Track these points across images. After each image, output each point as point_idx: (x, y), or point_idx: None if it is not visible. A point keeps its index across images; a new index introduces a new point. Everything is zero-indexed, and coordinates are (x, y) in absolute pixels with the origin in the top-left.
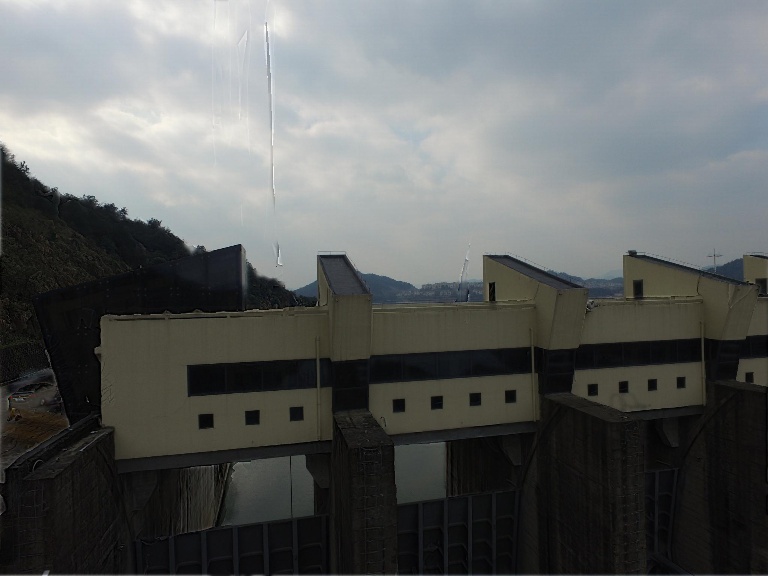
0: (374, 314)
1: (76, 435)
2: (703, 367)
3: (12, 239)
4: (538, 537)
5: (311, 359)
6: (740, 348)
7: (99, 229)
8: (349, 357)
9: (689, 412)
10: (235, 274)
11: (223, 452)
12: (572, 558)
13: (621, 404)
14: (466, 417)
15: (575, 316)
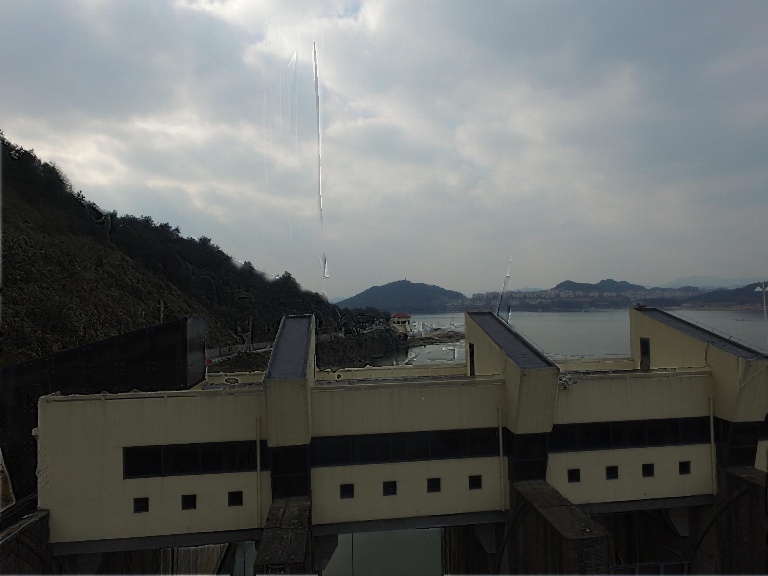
0: (320, 392)
1: (1, 524)
2: (712, 450)
3: (59, 268)
4: None
5: (251, 441)
6: (758, 430)
7: (148, 251)
8: (286, 443)
9: (696, 502)
10: (181, 347)
11: (159, 537)
12: None
13: (609, 492)
14: (423, 504)
15: (545, 398)
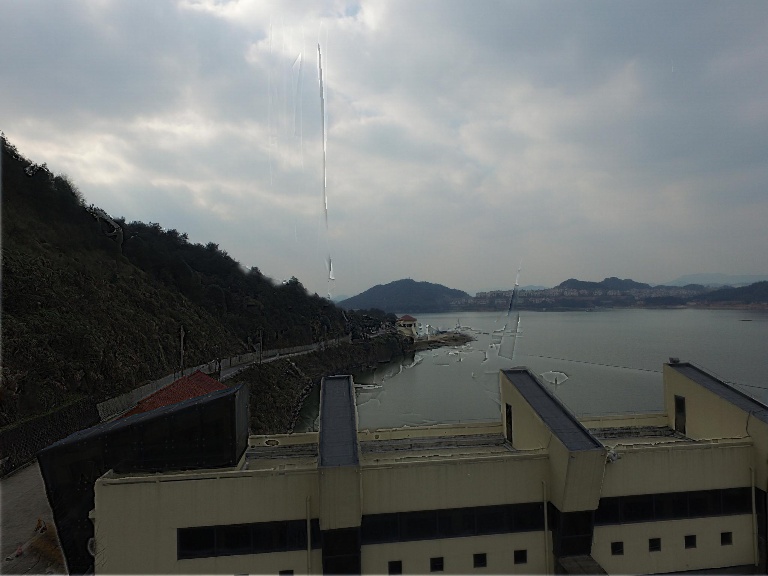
0: (368, 470)
1: None
2: (754, 521)
3: (76, 288)
4: None
5: (302, 520)
6: None
7: (158, 262)
8: (338, 525)
9: (737, 571)
10: (230, 423)
11: None
12: None
13: (652, 564)
14: None
15: (592, 478)
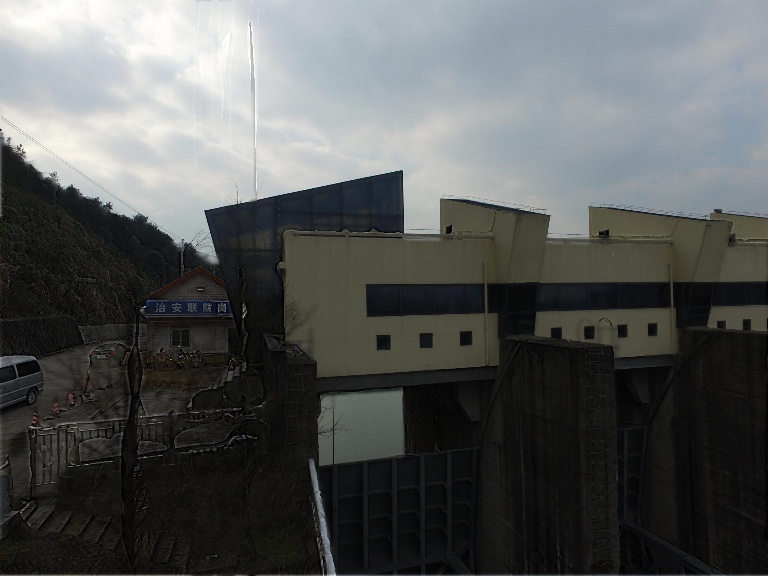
0: None
1: None
2: None
3: (26, 217)
4: (675, 469)
5: (478, 284)
6: None
7: (95, 218)
8: (522, 279)
9: None
10: (396, 201)
11: (398, 375)
12: (729, 480)
13: None
14: (614, 348)
15: (718, 249)
